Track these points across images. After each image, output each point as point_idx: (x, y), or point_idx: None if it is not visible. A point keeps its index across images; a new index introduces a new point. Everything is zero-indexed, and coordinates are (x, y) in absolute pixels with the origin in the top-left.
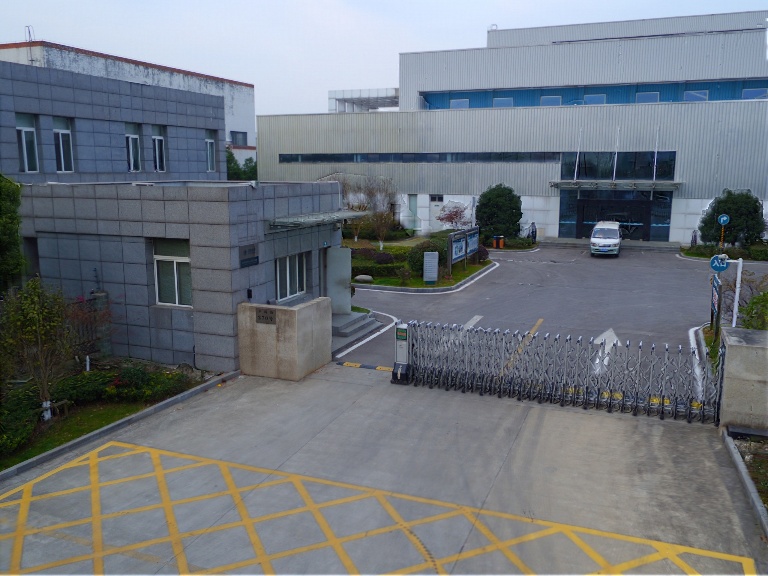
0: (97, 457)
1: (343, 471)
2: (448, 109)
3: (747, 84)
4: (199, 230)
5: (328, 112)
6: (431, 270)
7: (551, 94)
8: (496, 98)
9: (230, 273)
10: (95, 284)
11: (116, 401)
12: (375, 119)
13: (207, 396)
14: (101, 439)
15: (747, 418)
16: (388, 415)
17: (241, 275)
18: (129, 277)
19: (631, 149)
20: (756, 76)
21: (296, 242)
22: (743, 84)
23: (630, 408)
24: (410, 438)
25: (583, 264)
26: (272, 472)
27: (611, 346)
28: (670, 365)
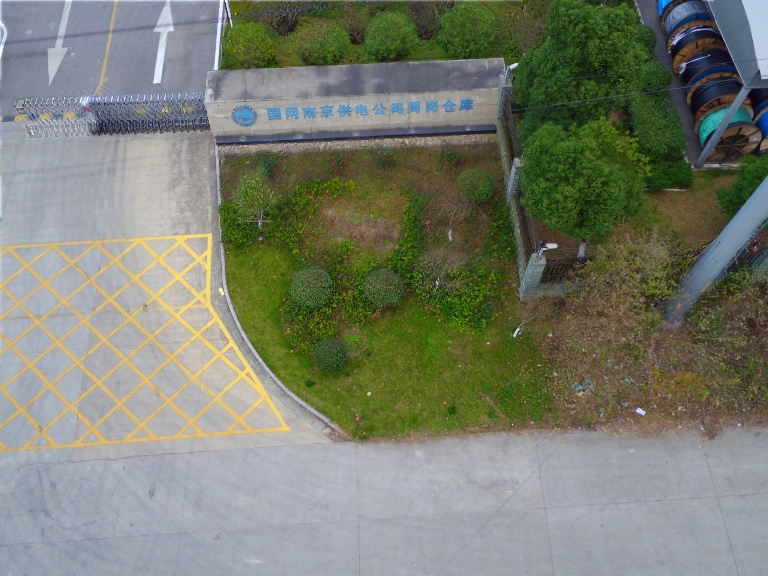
0: None
1: (31, 235)
2: None
3: None
4: None
5: None
6: None
7: None
8: None
9: None
10: None
11: None
12: None
13: None
14: None
15: (223, 133)
16: (39, 176)
17: None
18: None
19: None
20: None
21: None
22: None
23: (172, 127)
24: (57, 195)
25: None
26: None
27: (167, 33)
28: (201, 55)
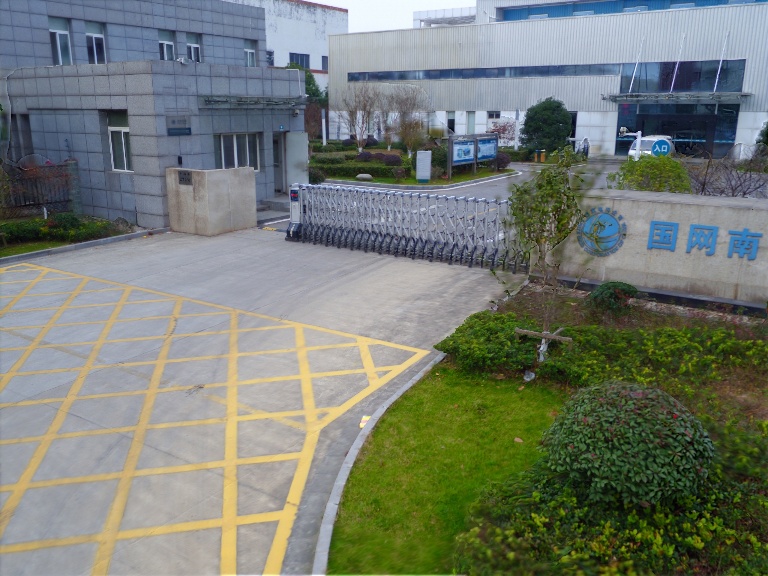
0: (4, 270)
1: (172, 286)
2: (508, 21)
3: None
4: (133, 101)
5: (393, 29)
6: (424, 169)
7: (635, 5)
8: (576, 12)
9: (156, 139)
10: (67, 153)
11: (49, 239)
12: (437, 34)
13: (127, 242)
14: (19, 261)
15: None
16: (254, 258)
17: (170, 142)
18: (90, 146)
19: (696, 58)
20: None
21: (242, 121)
22: None
23: None
24: (252, 271)
25: None
26: (117, 284)
27: None
28: None
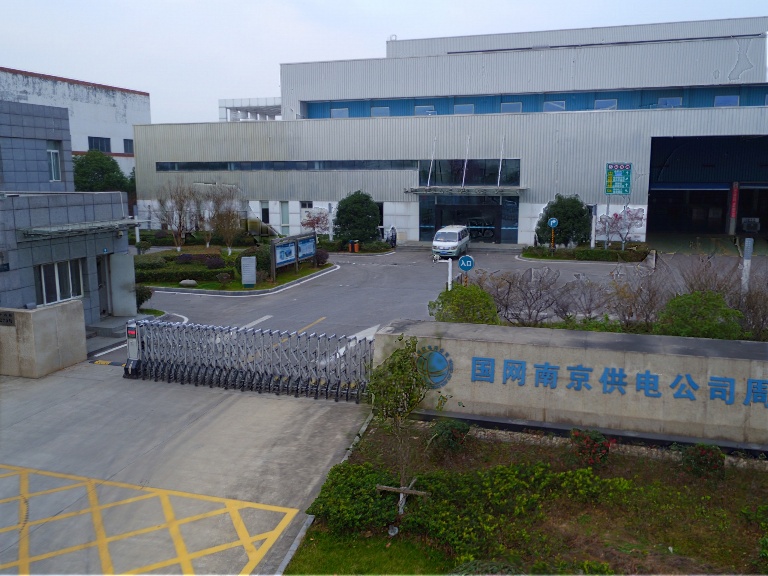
0: None
1: (10, 454)
2: (314, 119)
3: (599, 95)
4: None
5: (201, 121)
6: (249, 274)
7: (424, 104)
8: (374, 107)
9: None
10: None
11: None
12: (246, 128)
13: None
14: None
15: None
16: (95, 406)
17: None
18: None
19: (481, 157)
20: (604, 88)
21: (64, 249)
22: (595, 95)
23: None
24: (97, 424)
25: (419, 266)
26: None
27: None
28: None
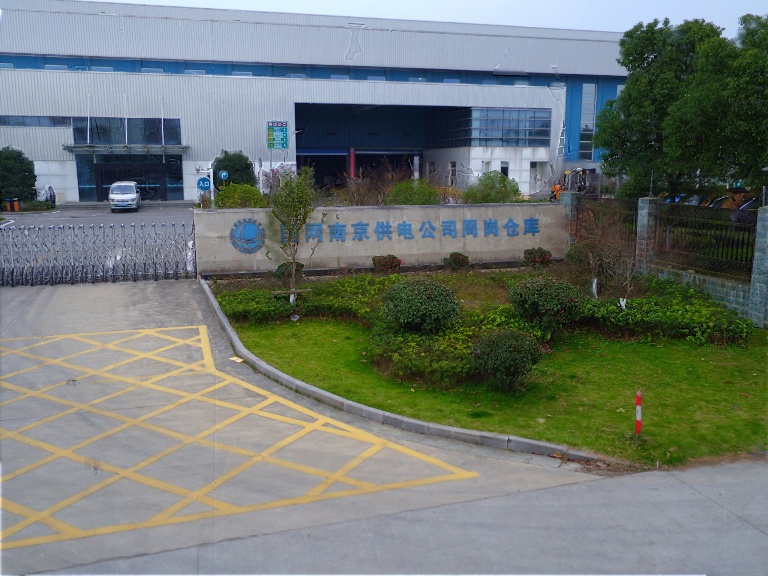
0: None
1: None
2: None
3: (235, 67)
4: None
5: None
6: None
7: (56, 63)
8: None
9: None
10: None
11: None
12: None
13: None
14: None
15: (214, 265)
16: None
17: None
18: None
19: (140, 116)
20: (241, 61)
21: None
22: (232, 67)
23: (131, 278)
24: None
25: (103, 217)
26: None
27: None
28: None
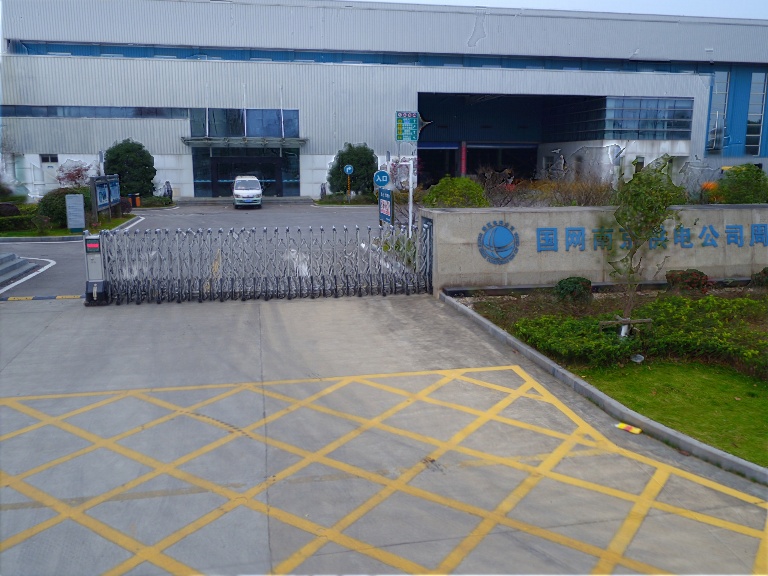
0: None
1: (73, 383)
2: (53, 55)
3: (345, 57)
4: None
5: None
6: (76, 215)
7: (165, 54)
8: (104, 54)
9: None
10: None
11: None
12: None
13: None
14: None
15: (458, 278)
16: (100, 331)
17: None
18: None
19: (258, 107)
20: (352, 49)
21: None
22: (342, 56)
23: (353, 292)
24: (141, 344)
25: (232, 214)
26: None
27: None
28: None
